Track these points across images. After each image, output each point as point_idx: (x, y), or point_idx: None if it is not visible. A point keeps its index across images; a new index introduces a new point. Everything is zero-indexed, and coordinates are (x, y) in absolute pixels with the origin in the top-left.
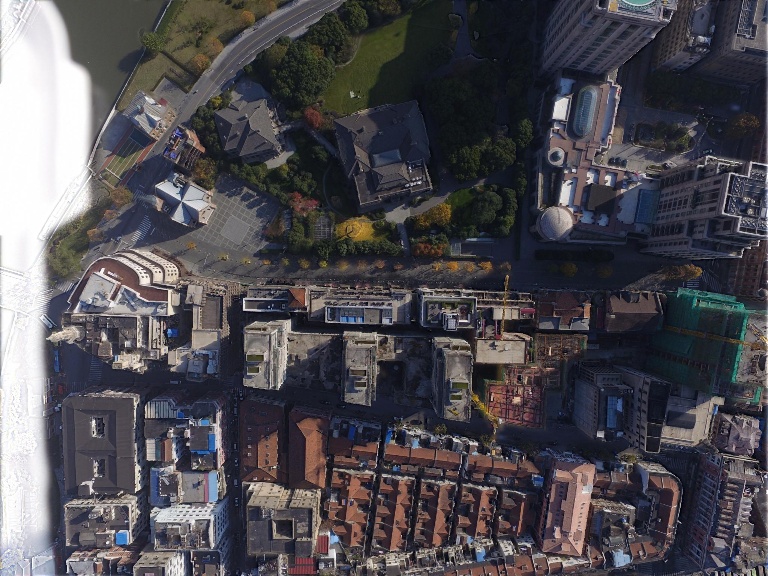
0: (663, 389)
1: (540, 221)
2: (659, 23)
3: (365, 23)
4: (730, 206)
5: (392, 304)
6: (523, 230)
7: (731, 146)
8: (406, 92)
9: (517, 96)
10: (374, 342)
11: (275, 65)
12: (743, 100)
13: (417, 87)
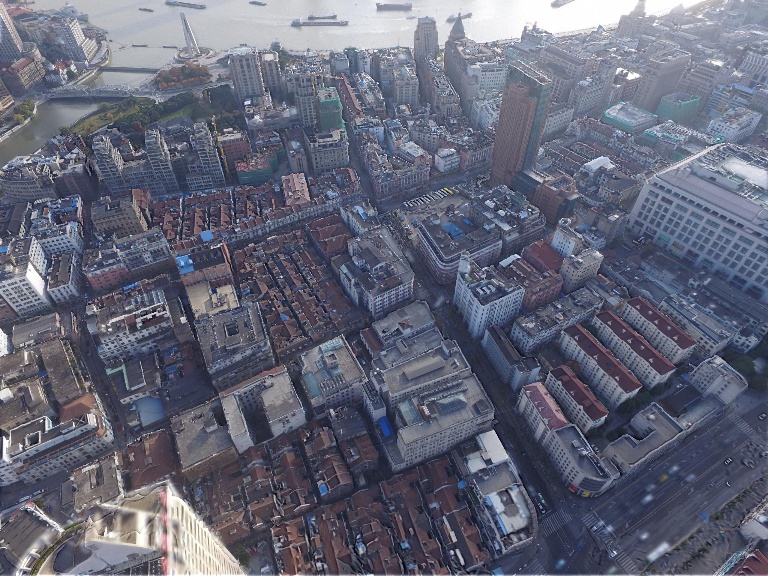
0: None
1: None
2: (253, 55)
3: (162, 108)
4: None
5: None
6: None
7: None
8: None
9: None
10: None
11: (121, 120)
12: None
13: None
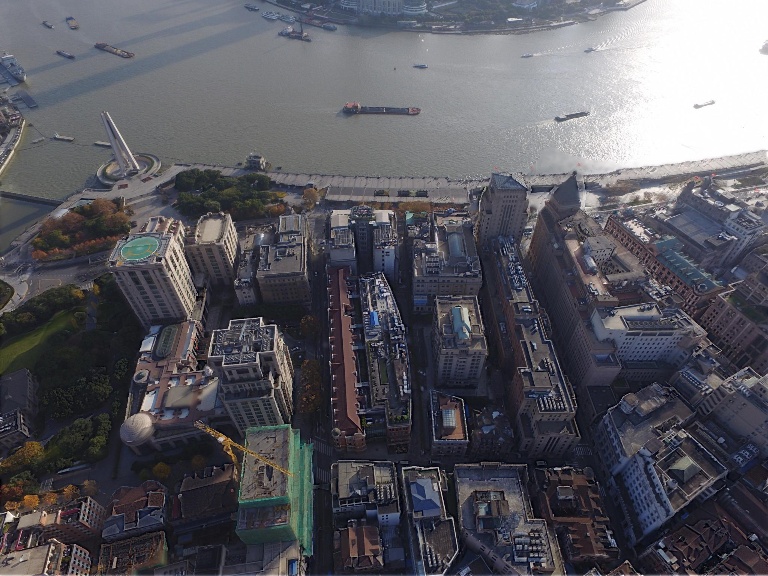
0: (210, 553)
1: (120, 429)
2: (157, 265)
3: (1, 331)
4: (216, 351)
5: None
6: (124, 449)
7: (313, 341)
8: (32, 369)
9: (120, 347)
10: None
11: None
12: (316, 313)
13: (38, 362)
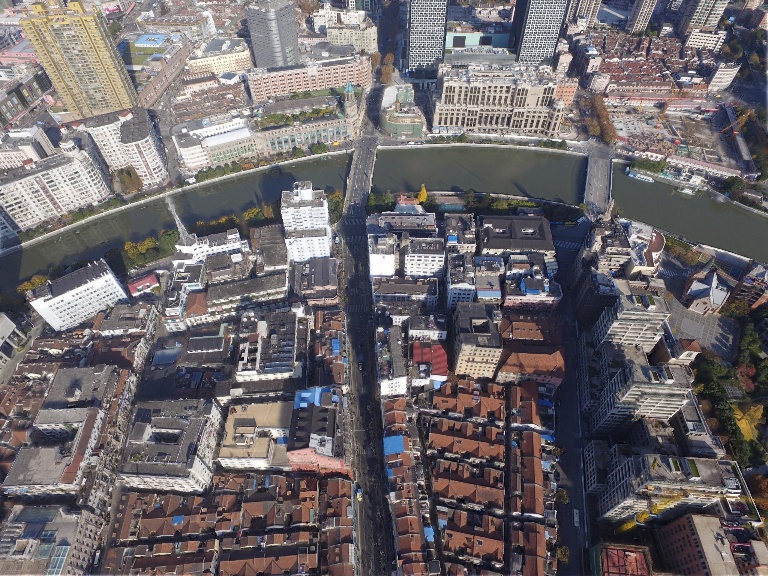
0: None
1: None
2: None
3: None
4: None
5: (706, 435)
6: None
7: None
8: None
9: None
10: (688, 398)
11: None
12: None
13: None
